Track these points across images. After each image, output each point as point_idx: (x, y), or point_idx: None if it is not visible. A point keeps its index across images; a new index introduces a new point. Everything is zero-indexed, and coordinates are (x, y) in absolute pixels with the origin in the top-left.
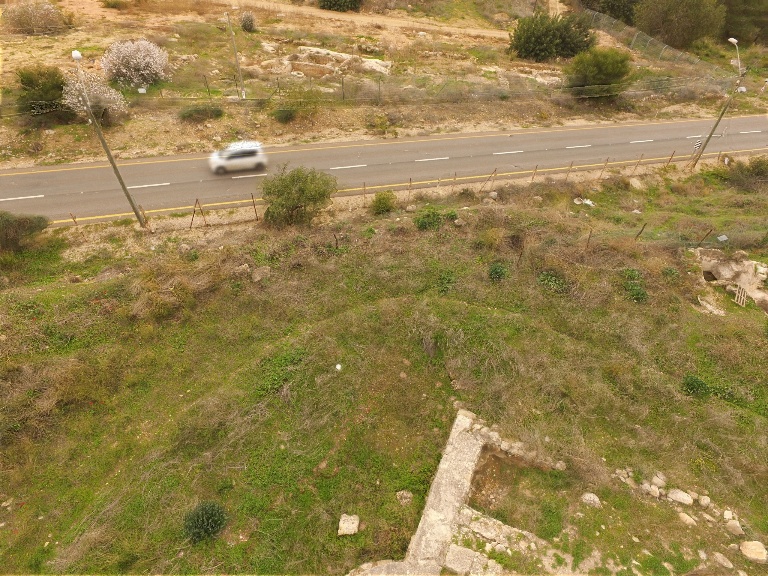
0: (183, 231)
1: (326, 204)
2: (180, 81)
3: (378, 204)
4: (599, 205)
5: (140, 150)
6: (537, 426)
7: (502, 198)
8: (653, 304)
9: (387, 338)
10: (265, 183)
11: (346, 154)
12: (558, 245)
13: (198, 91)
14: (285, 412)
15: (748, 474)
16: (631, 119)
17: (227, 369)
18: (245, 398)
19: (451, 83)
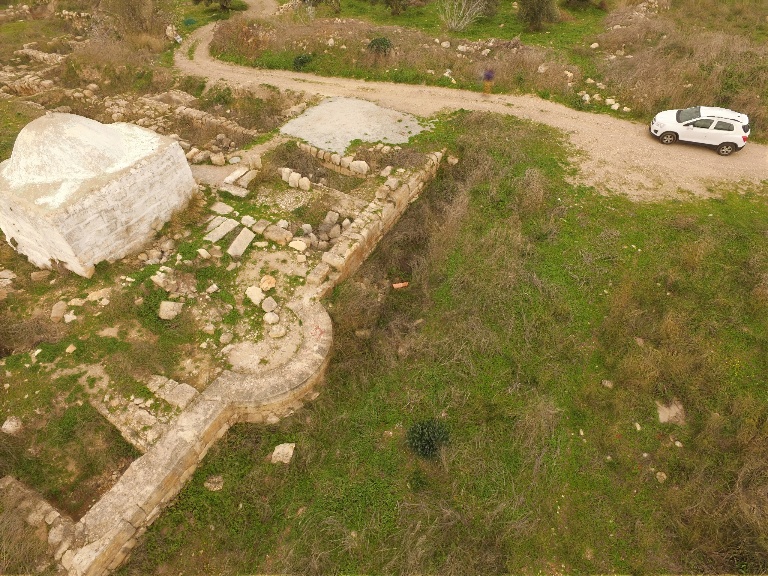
0: None
1: None
2: None
3: None
4: None
5: None
6: None
7: None
8: None
9: None
10: None
11: None
12: None
13: None
14: None
15: None
16: None
17: None
18: None
19: None
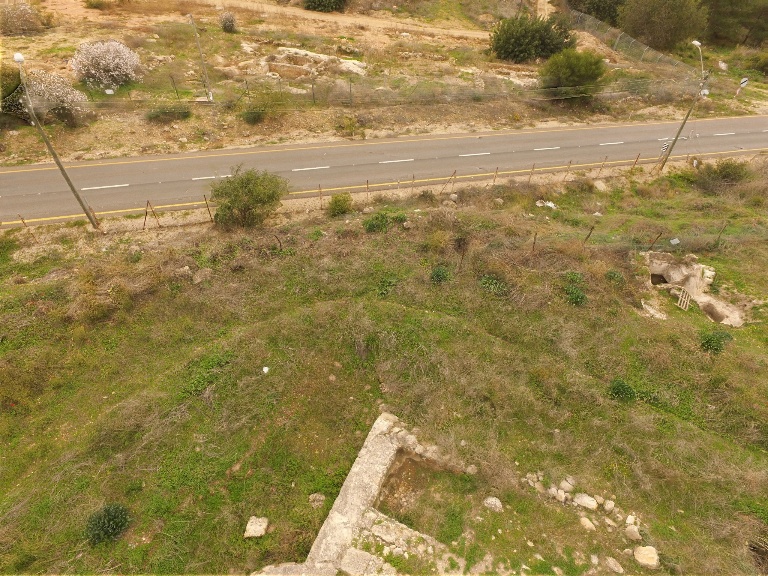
0: (136, 232)
1: (275, 206)
2: (152, 82)
3: (334, 206)
4: (561, 207)
5: (104, 151)
6: (454, 430)
7: (462, 200)
8: (592, 308)
9: (318, 341)
10: (212, 185)
11: (310, 156)
12: (502, 248)
13: (169, 92)
14: (205, 414)
15: (660, 479)
16: (605, 121)
17: (155, 371)
18: (168, 400)
19: (423, 85)
